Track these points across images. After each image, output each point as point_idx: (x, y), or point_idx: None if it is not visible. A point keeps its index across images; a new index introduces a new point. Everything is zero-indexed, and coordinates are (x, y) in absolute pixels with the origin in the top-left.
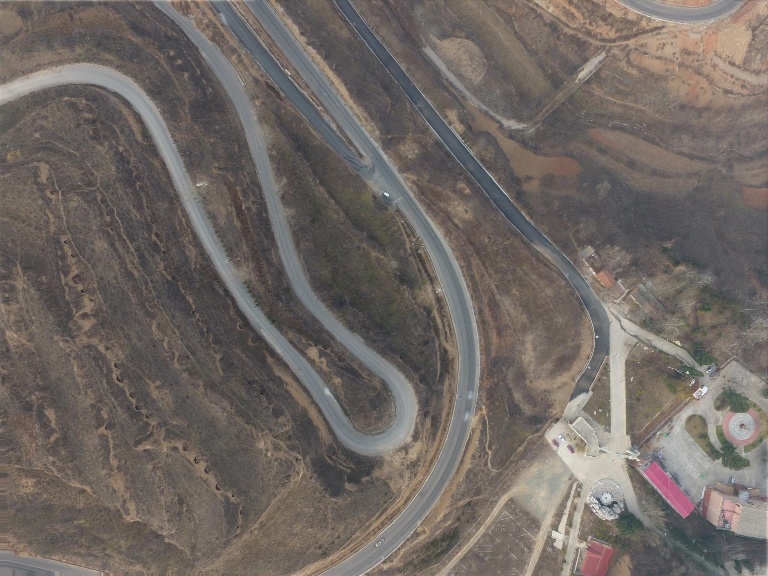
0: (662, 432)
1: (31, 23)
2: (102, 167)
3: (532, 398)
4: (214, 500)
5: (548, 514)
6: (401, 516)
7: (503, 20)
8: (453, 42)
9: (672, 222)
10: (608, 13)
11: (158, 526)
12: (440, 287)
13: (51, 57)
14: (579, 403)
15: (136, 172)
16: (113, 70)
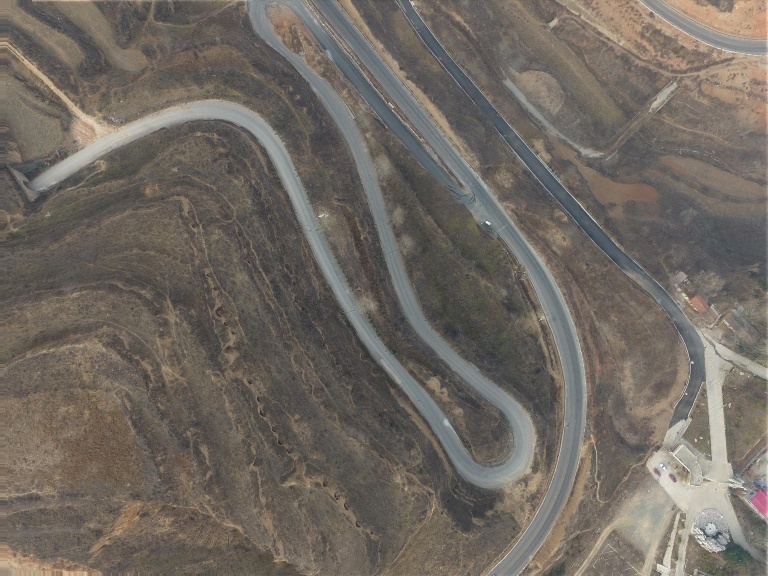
0: (762, 459)
1: (156, 61)
2: (238, 200)
3: (632, 426)
4: (357, 538)
5: (652, 546)
6: (512, 551)
7: (574, 53)
8: (531, 74)
9: (753, 247)
10: (680, 46)
11: (304, 566)
12: (543, 314)
13: (180, 94)
14: (678, 430)
15: (267, 205)
16: (240, 106)
